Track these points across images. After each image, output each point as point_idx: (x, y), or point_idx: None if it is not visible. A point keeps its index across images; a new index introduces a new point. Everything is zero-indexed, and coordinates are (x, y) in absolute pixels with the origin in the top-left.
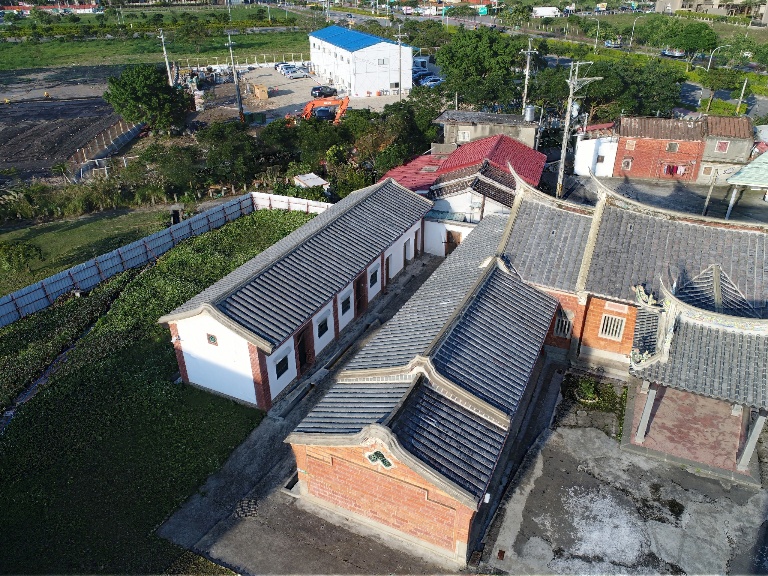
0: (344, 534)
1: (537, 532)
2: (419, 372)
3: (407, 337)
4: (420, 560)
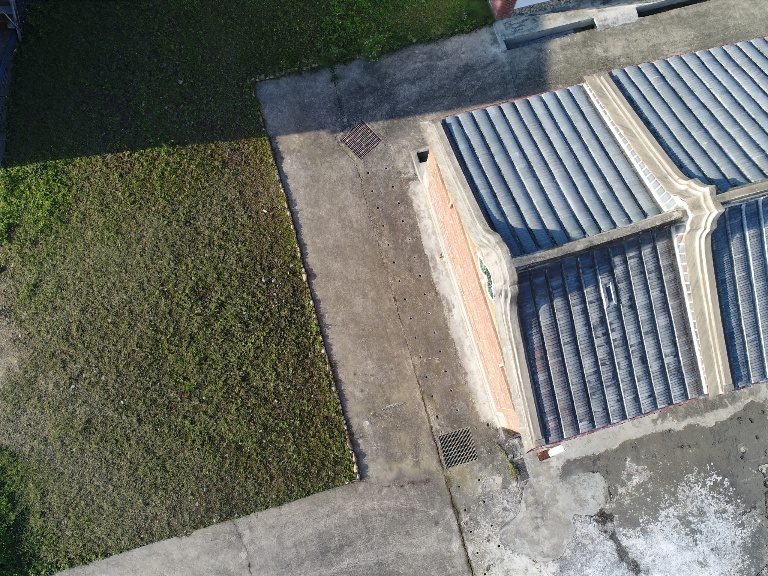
0: (422, 269)
1: (612, 476)
2: (683, 210)
3: (765, 105)
4: (463, 374)
